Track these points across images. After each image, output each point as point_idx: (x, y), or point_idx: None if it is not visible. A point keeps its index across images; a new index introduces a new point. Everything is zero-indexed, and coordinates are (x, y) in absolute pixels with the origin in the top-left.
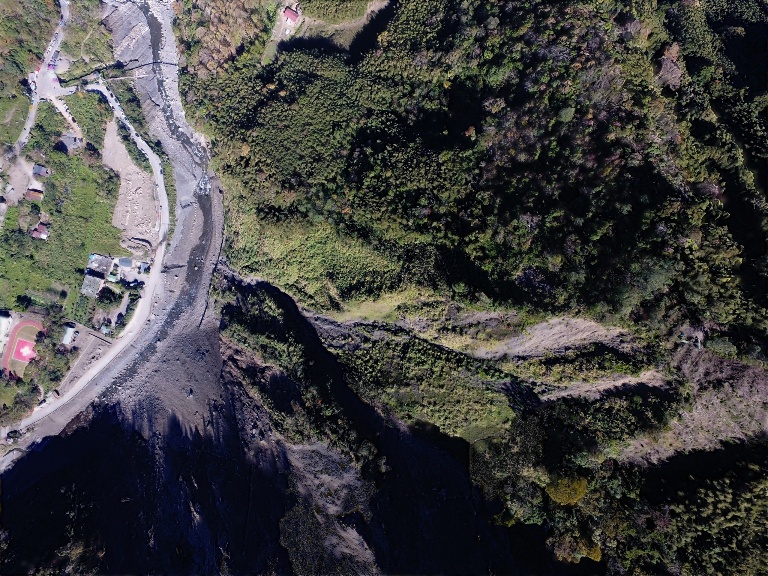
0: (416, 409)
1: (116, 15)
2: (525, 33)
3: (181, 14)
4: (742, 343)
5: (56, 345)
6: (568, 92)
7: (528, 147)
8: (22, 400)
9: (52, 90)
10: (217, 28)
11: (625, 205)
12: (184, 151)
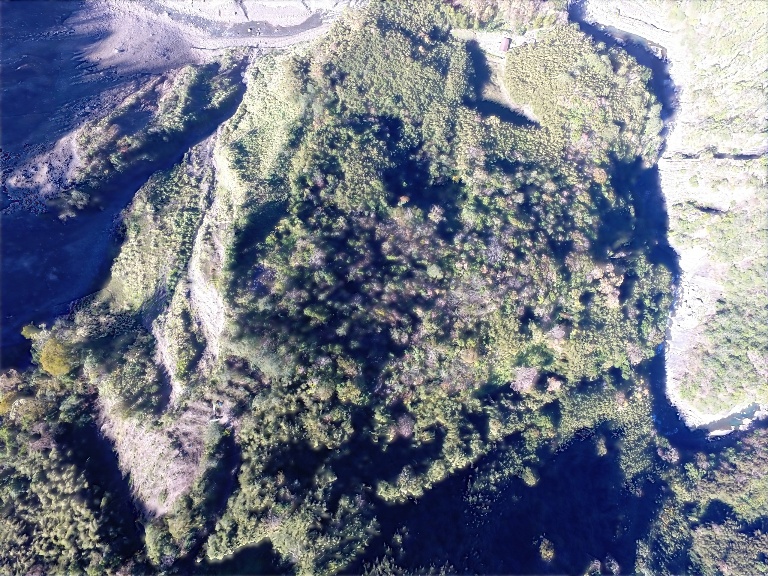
0: (132, 233)
1: None
2: (512, 224)
3: None
4: (221, 454)
5: None
6: (458, 268)
7: (398, 249)
8: None
9: None
10: None
11: (345, 329)
12: None
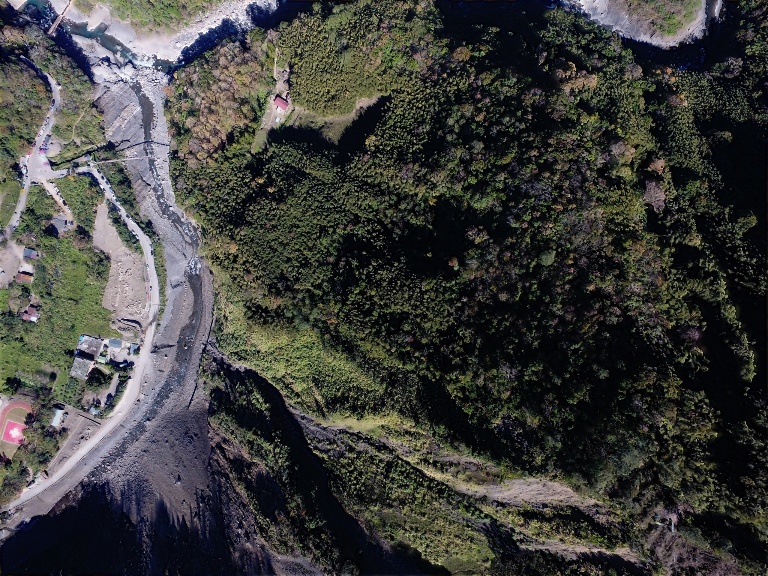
0: (398, 532)
1: (108, 96)
2: (508, 163)
3: (172, 97)
4: (715, 533)
5: (45, 427)
6: (549, 233)
7: (509, 286)
8: (11, 483)
9: (43, 174)
10: (207, 119)
11: (602, 369)
12: (175, 230)
